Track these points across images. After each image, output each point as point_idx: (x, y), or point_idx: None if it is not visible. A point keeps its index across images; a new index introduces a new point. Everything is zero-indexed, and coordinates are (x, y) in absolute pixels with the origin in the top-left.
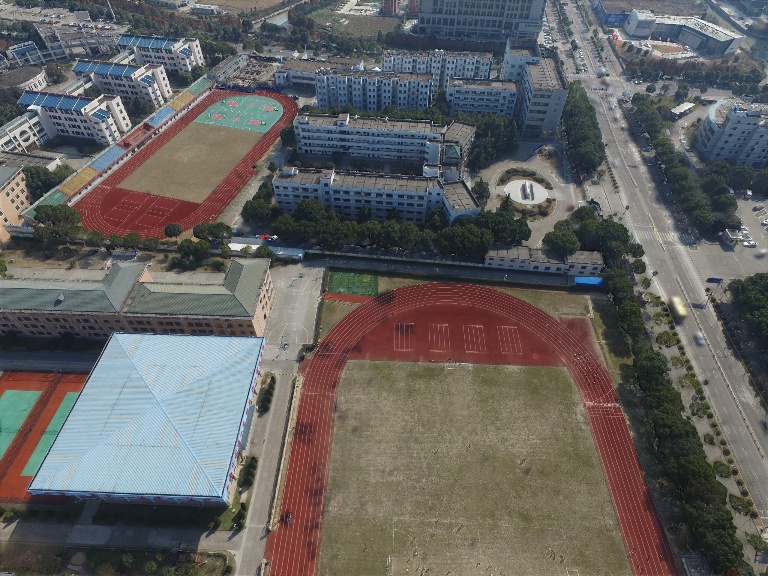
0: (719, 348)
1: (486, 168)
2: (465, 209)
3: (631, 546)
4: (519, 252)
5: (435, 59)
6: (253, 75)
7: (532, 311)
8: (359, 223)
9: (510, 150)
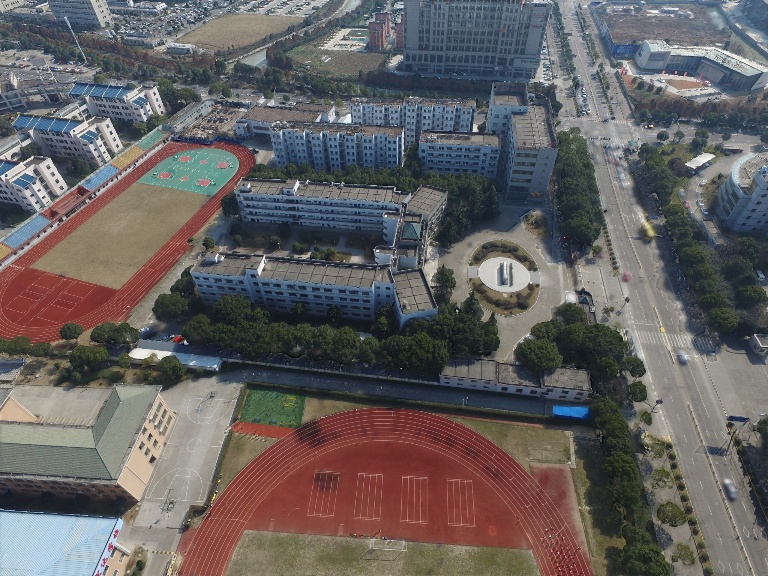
0: (746, 523)
1: (459, 241)
2: (418, 310)
3: None
4: (483, 369)
5: (409, 108)
6: (215, 124)
7: (495, 455)
8: (293, 322)
9: (489, 218)
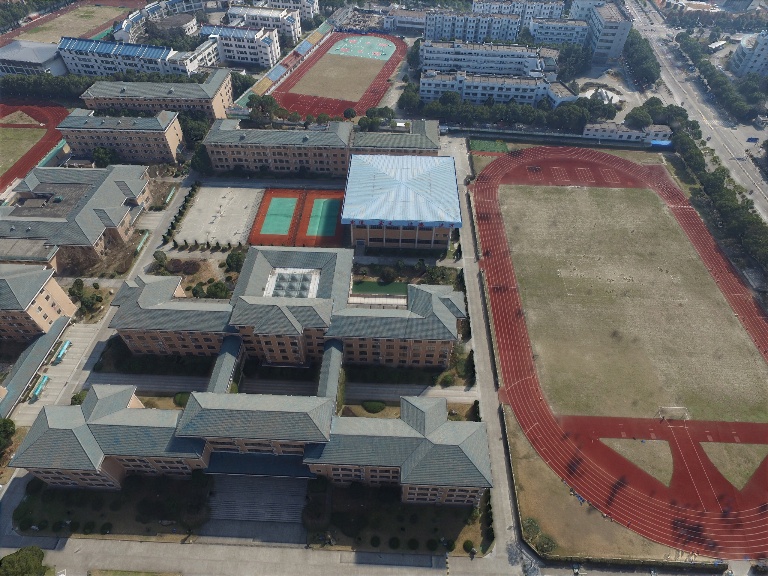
0: (758, 180)
1: (568, 82)
2: (567, 97)
3: (710, 267)
4: (609, 125)
5: (518, 5)
6: (361, 23)
7: (622, 161)
8: None
9: (585, 70)
